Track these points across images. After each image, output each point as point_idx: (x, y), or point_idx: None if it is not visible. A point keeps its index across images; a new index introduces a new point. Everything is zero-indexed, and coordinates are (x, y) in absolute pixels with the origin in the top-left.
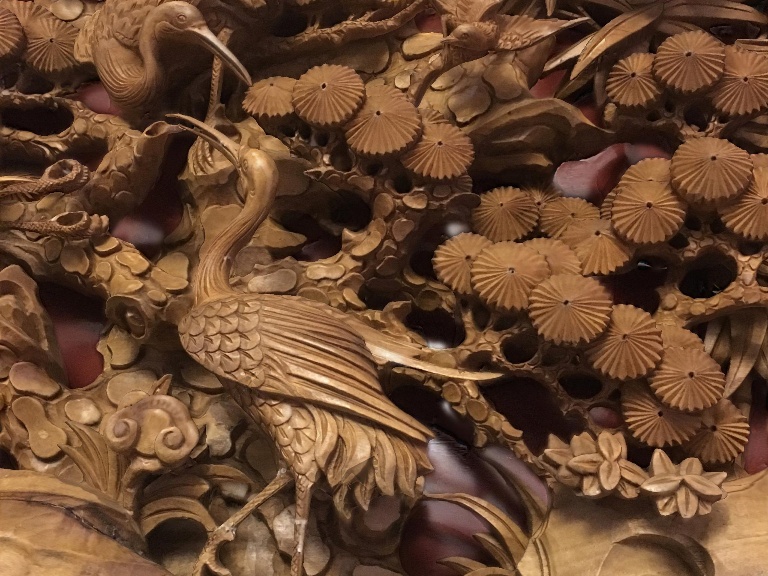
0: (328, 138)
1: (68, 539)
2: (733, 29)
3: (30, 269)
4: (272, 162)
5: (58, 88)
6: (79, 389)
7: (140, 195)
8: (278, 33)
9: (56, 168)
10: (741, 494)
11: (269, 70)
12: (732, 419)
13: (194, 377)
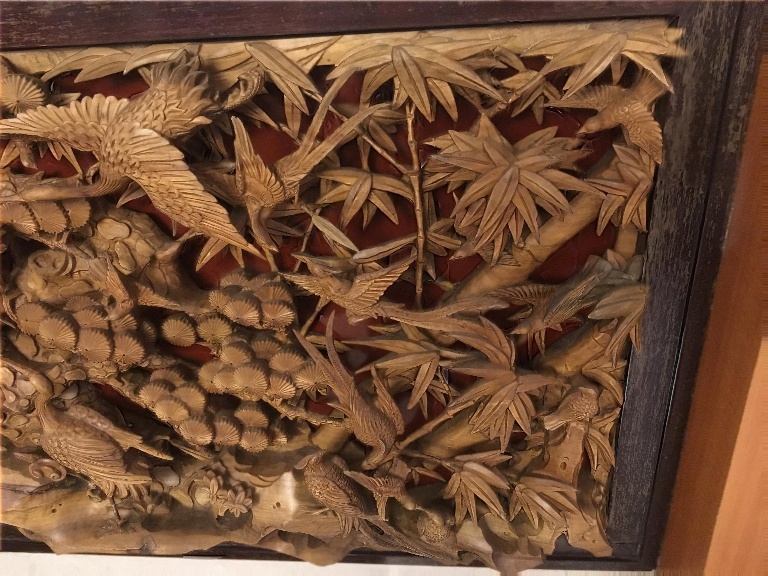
0: None
1: (36, 501)
2: (296, 215)
3: None
4: (44, 384)
5: None
6: None
7: None
8: None
9: None
10: (266, 490)
11: None
12: (279, 438)
13: (61, 395)
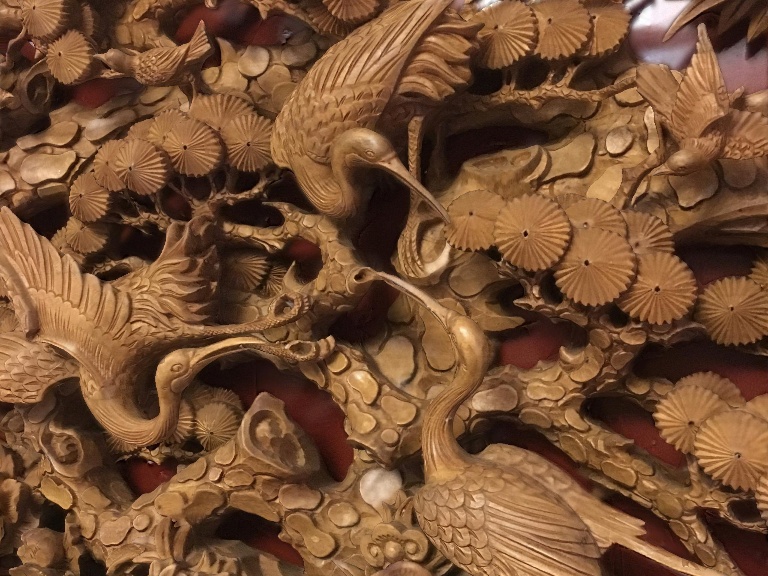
0: None
1: None
2: None
3: (275, 366)
4: (480, 337)
5: (264, 180)
6: (337, 490)
7: (359, 301)
8: (472, 90)
9: (279, 303)
10: None
11: (467, 116)
12: None
13: None
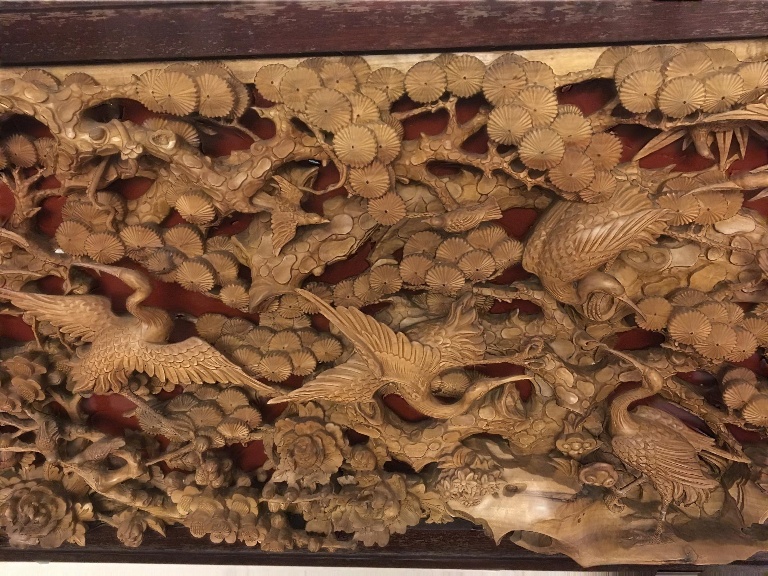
0: None
1: (569, 509)
2: None
3: None
4: None
5: None
6: (534, 414)
7: None
8: None
9: None
10: None
11: None
12: None
13: None
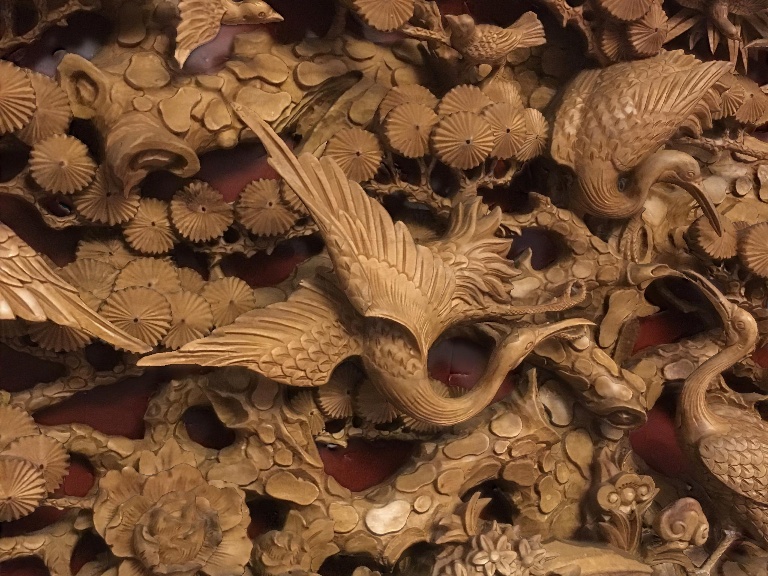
0: (747, 275)
1: None
2: None
3: (495, 344)
4: None
5: (514, 169)
6: (553, 453)
7: None
8: None
9: None
10: None
11: None
12: None
13: (608, 431)
